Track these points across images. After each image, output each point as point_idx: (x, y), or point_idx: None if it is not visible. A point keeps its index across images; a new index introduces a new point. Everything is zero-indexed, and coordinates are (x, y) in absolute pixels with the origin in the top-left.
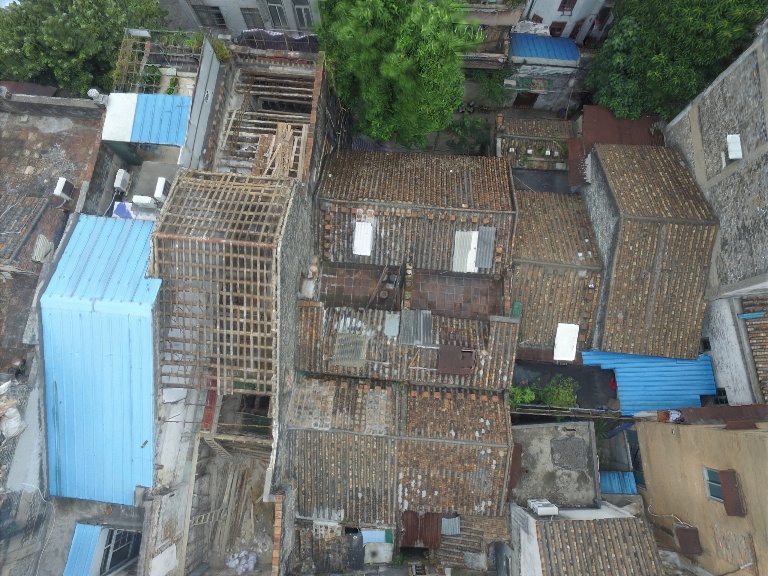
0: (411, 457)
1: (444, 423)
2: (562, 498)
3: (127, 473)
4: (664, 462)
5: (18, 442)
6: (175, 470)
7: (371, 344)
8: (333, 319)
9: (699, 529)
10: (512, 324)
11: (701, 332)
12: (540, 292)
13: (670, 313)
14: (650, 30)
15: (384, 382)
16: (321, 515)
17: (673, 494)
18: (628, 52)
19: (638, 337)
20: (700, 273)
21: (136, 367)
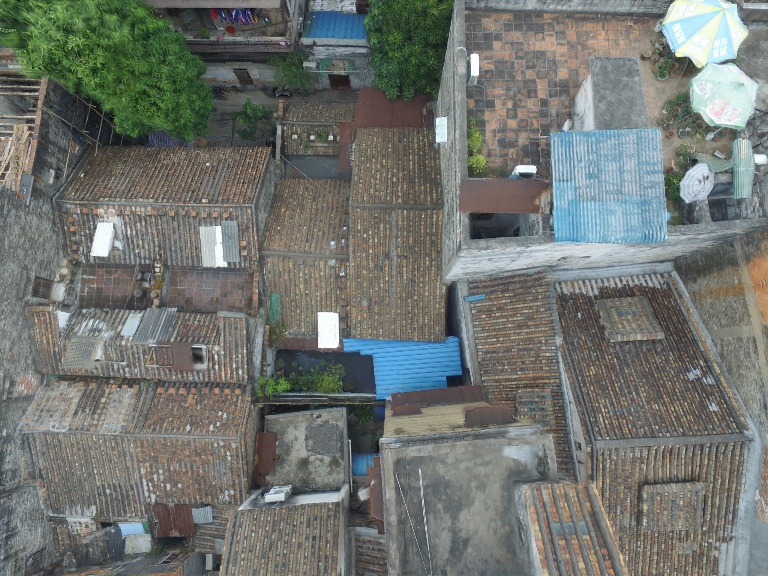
0: (149, 453)
1: (182, 418)
2: (313, 482)
3: None
4: None
5: None
6: None
7: (107, 345)
8: (76, 322)
9: None
10: (238, 319)
11: (445, 315)
12: (295, 283)
13: (413, 298)
14: (390, 8)
15: (135, 380)
16: (74, 512)
17: None
18: (382, 31)
19: (385, 323)
20: (435, 257)
21: None
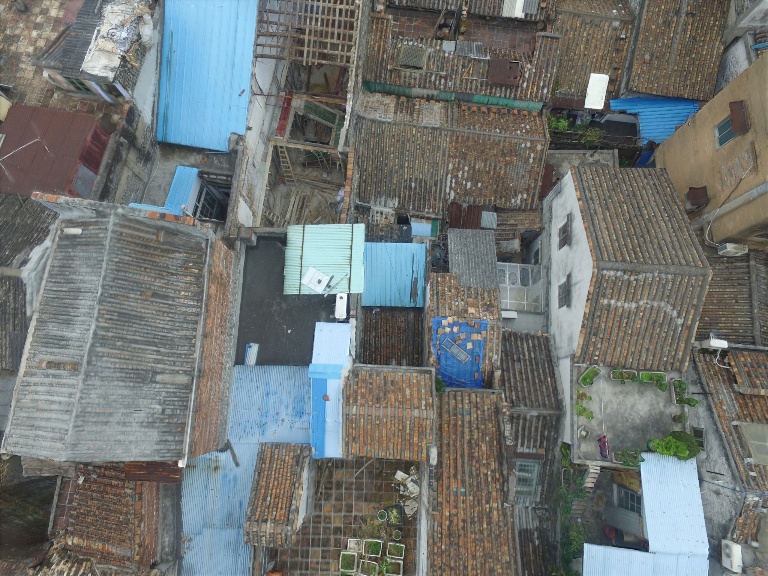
0: (460, 149)
1: (490, 125)
2: None
3: (224, 120)
4: (679, 159)
5: (143, 65)
6: (254, 157)
7: (431, 56)
8: (398, 41)
9: (707, 184)
10: (555, 39)
11: (717, 74)
12: (577, 42)
13: (691, 56)
14: None
15: (438, 101)
16: (378, 203)
17: (686, 178)
18: None
19: (661, 78)
20: (720, 17)
21: (242, 18)
